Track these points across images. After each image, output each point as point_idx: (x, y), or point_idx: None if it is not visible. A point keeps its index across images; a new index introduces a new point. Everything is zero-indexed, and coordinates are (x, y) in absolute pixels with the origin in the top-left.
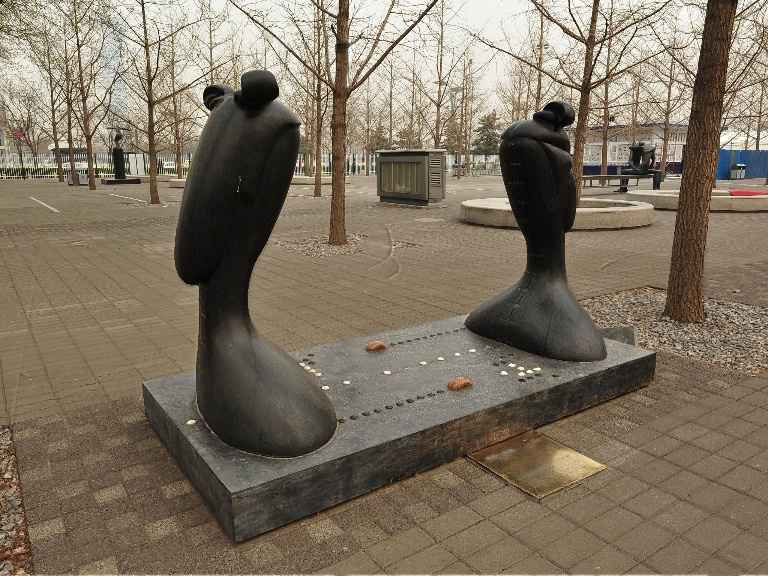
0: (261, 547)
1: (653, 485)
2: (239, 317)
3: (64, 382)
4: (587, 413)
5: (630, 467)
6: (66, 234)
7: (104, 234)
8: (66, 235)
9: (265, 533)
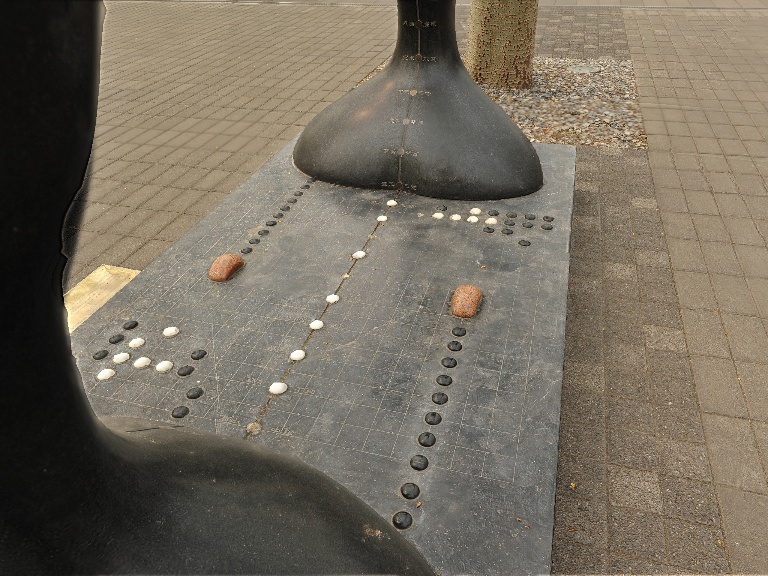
0: None
1: None
2: None
3: (767, 181)
4: None
5: None
6: None
7: None
8: None
9: None
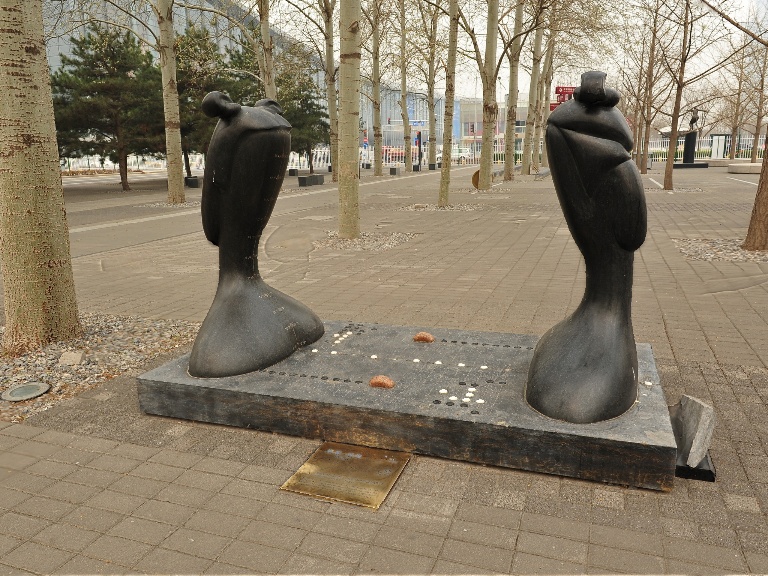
0: (146, 421)
1: (373, 544)
2: (232, 274)
3: None
4: (506, 473)
5: (399, 523)
6: (528, 213)
7: (554, 215)
8: (526, 214)
9: (160, 416)
